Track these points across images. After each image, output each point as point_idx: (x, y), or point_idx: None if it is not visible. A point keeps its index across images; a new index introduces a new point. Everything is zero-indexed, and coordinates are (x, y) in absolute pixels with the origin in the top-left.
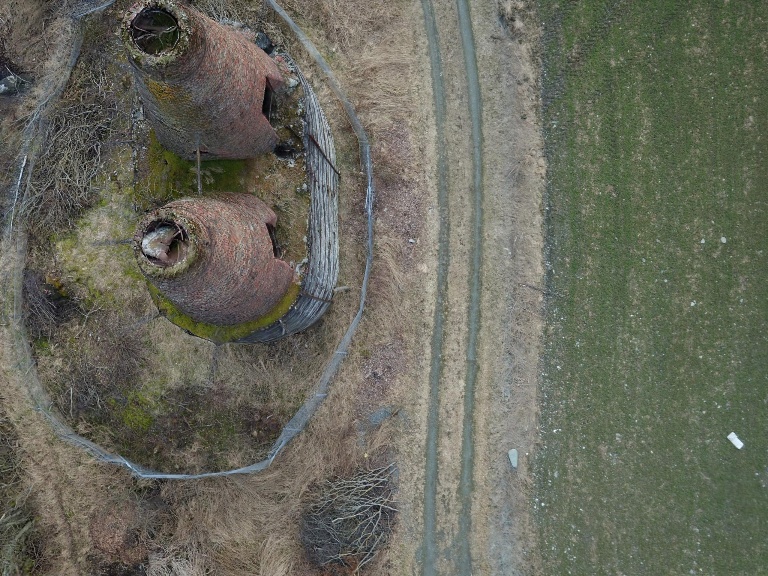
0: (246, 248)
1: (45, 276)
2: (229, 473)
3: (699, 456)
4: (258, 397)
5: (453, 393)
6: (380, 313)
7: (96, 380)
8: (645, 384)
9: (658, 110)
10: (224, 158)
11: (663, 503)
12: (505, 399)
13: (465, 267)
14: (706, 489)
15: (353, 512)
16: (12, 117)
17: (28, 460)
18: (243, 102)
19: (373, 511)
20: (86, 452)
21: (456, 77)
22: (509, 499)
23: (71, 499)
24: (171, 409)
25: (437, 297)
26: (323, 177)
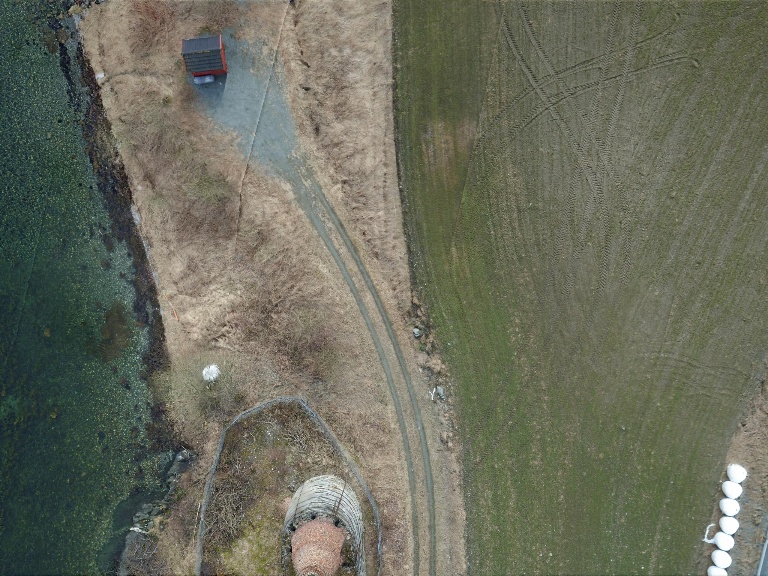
0: None
1: (213, 566)
2: None
3: None
4: None
5: None
6: None
7: None
8: None
9: (519, 490)
10: None
11: None
12: None
13: (427, 566)
14: None
15: None
16: (187, 475)
17: None
18: None
19: None
20: None
21: (420, 471)
22: None
23: None
24: None
25: None
26: None
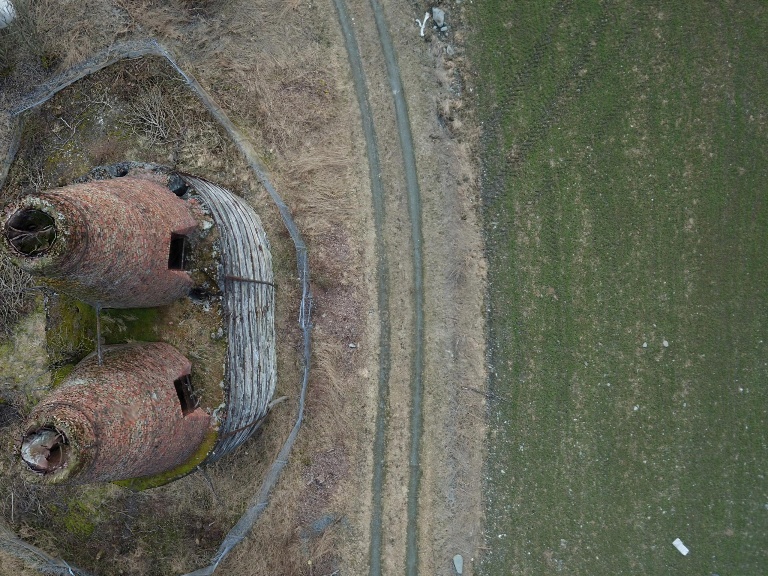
0: (144, 424)
1: None
2: None
3: (645, 562)
4: (200, 504)
5: (396, 499)
6: (320, 421)
7: (36, 486)
8: (589, 489)
9: (598, 212)
10: (135, 307)
11: None
12: (449, 504)
13: (406, 371)
14: None
15: None
16: None
17: None
18: (142, 270)
19: None
20: (29, 556)
21: (395, 178)
22: None
23: None
24: (112, 516)
25: (379, 402)
26: (249, 302)
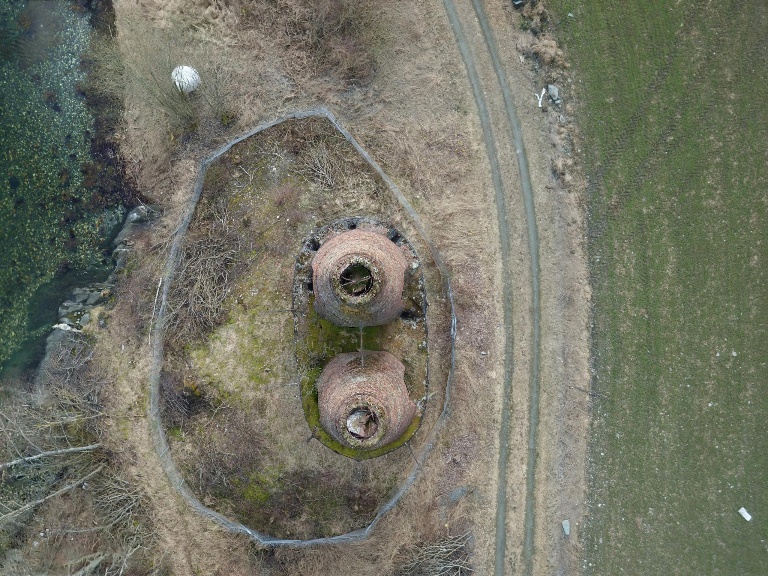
0: (401, 409)
1: (178, 377)
2: (333, 539)
3: (716, 526)
4: (358, 478)
5: (518, 475)
6: (459, 412)
7: (223, 463)
8: (672, 468)
9: (681, 249)
10: (367, 326)
11: (687, 564)
12: (559, 479)
13: (526, 374)
14: (722, 553)
15: (438, 572)
16: (144, 241)
17: (162, 527)
18: (395, 301)
19: (453, 571)
20: (211, 520)
21: (518, 220)
22: (563, 560)
23: (199, 559)
24: (286, 487)
25: (504, 398)
26: None
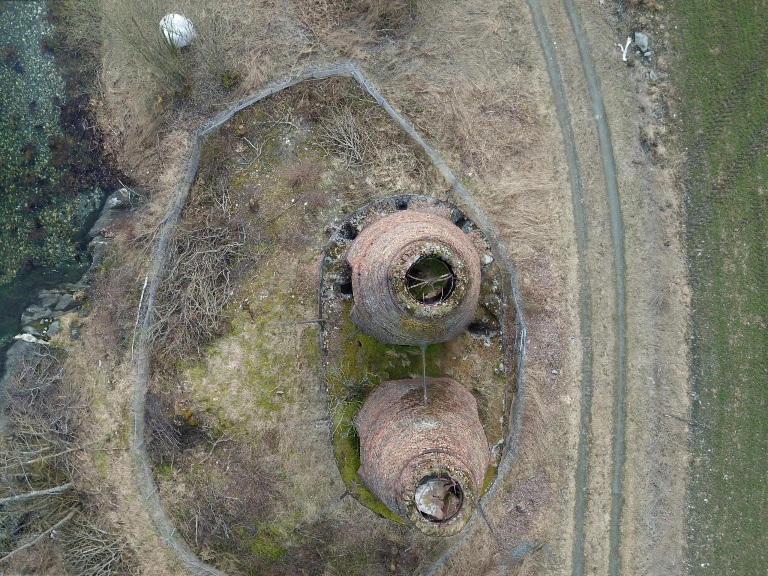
0: (484, 467)
1: (168, 401)
2: None
3: None
4: (395, 530)
5: (598, 527)
6: (525, 448)
7: (224, 510)
8: None
9: None
10: None
11: None
12: (650, 532)
13: (609, 398)
14: None
15: None
16: (126, 232)
17: None
18: None
19: None
20: None
21: (597, 203)
22: None
23: None
24: (304, 541)
25: (581, 429)
26: None
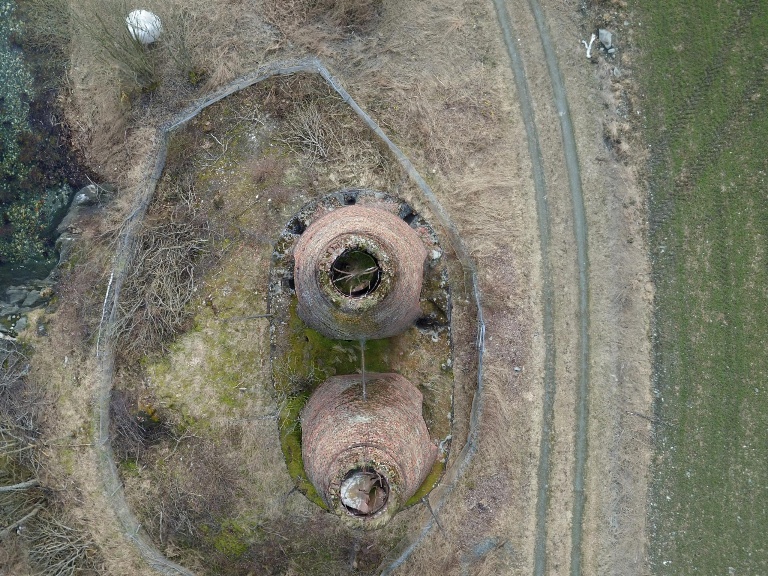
0: (420, 462)
1: (133, 397)
2: None
3: None
4: None
5: (560, 525)
6: (486, 445)
7: (188, 506)
8: (759, 517)
9: None
10: None
11: None
12: (613, 529)
13: (571, 395)
14: None
15: None
16: (94, 228)
17: None
18: (411, 305)
19: None
20: (174, 575)
21: (561, 200)
22: None
23: None
24: (267, 537)
25: (543, 426)
26: None
